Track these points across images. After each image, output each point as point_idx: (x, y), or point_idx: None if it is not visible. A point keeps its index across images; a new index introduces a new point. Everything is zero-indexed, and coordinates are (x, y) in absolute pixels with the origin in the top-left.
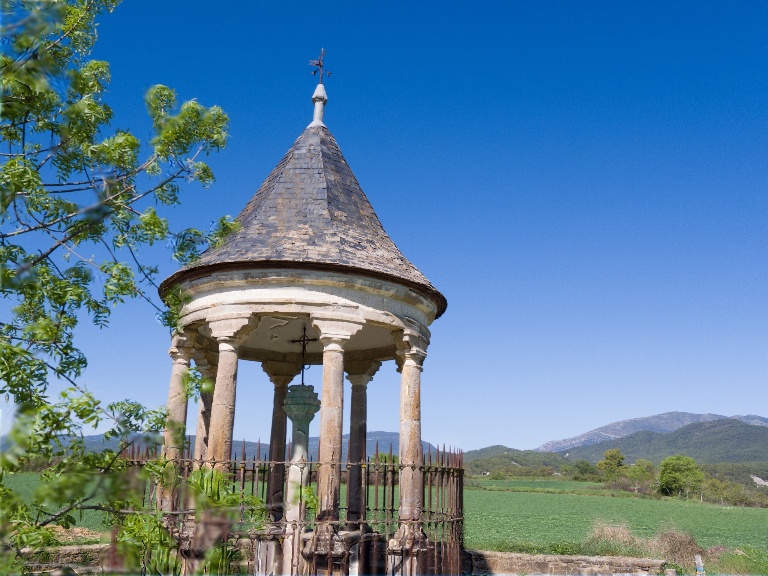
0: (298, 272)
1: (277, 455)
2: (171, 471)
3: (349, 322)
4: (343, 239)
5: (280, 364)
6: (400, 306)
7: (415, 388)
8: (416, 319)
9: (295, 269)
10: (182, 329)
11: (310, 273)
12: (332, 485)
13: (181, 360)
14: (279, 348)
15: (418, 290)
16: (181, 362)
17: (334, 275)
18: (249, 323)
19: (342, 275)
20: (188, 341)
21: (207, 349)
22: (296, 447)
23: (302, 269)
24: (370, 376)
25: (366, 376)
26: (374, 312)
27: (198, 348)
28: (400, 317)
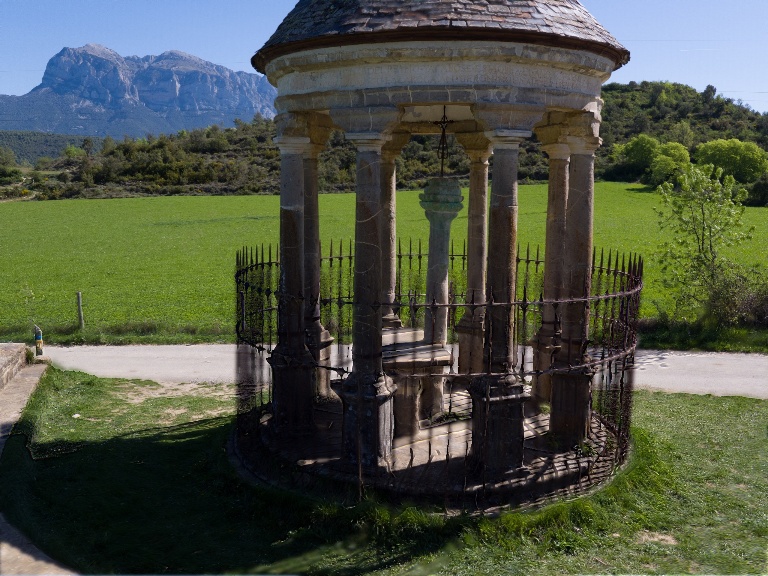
0: None
1: None
2: None
3: None
4: None
5: None
6: None
7: None
8: None
9: None
10: None
11: None
12: None
13: None
14: None
15: None
16: None
17: None
18: None
19: None
20: None
21: None
22: None
23: None
24: None
25: None
26: None
27: None
28: None
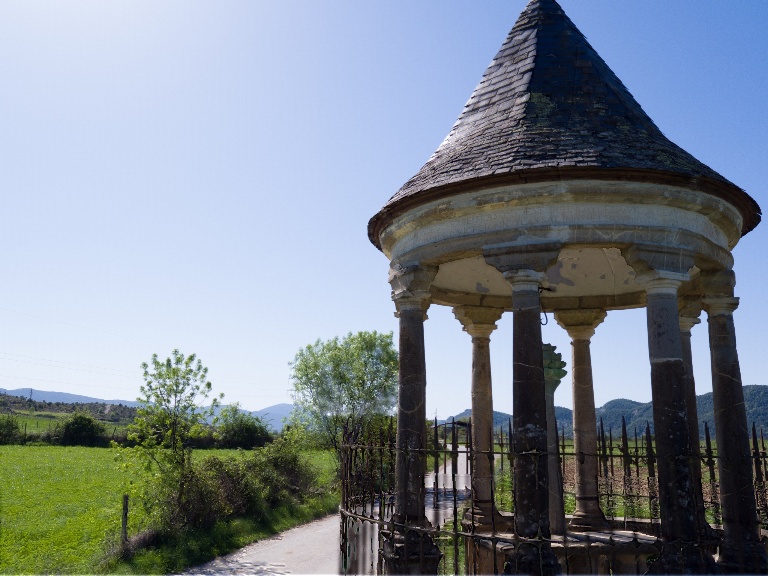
0: None
1: None
2: None
3: None
4: None
5: None
6: None
7: None
8: None
9: None
10: None
11: None
12: None
13: None
14: None
15: None
16: None
17: None
18: None
19: None
20: None
21: None
22: None
23: None
24: (650, 273)
25: (640, 278)
26: None
27: None
28: None
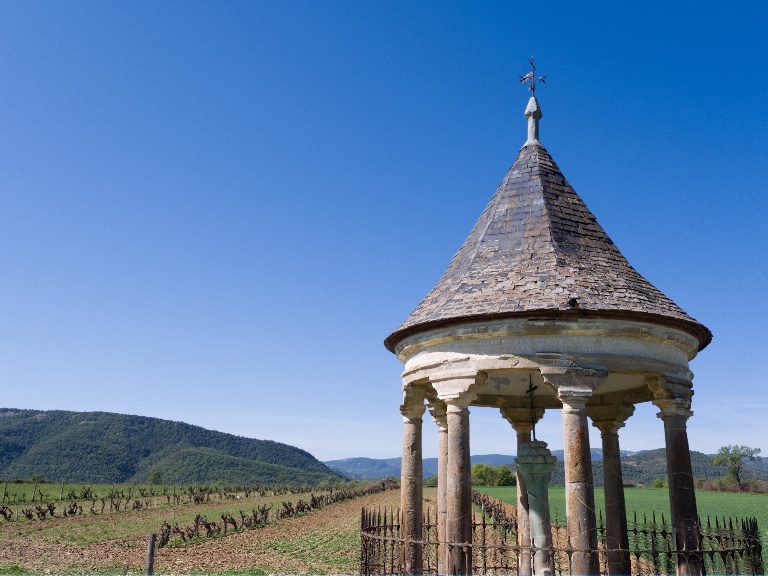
0: (415, 338)
1: (608, 515)
2: (441, 534)
3: (460, 378)
4: (464, 285)
5: (598, 408)
6: (530, 342)
7: (571, 440)
8: (569, 350)
9: (413, 335)
10: (428, 400)
11: (422, 336)
12: (451, 563)
13: (441, 428)
14: (596, 390)
15: (546, 316)
16: (440, 430)
17: (438, 332)
18: (408, 394)
19: (444, 329)
20: (437, 410)
21: (506, 407)
22: (529, 512)
23: (416, 334)
24: None
25: None
26: (488, 360)
27: (500, 407)
28: (528, 356)
